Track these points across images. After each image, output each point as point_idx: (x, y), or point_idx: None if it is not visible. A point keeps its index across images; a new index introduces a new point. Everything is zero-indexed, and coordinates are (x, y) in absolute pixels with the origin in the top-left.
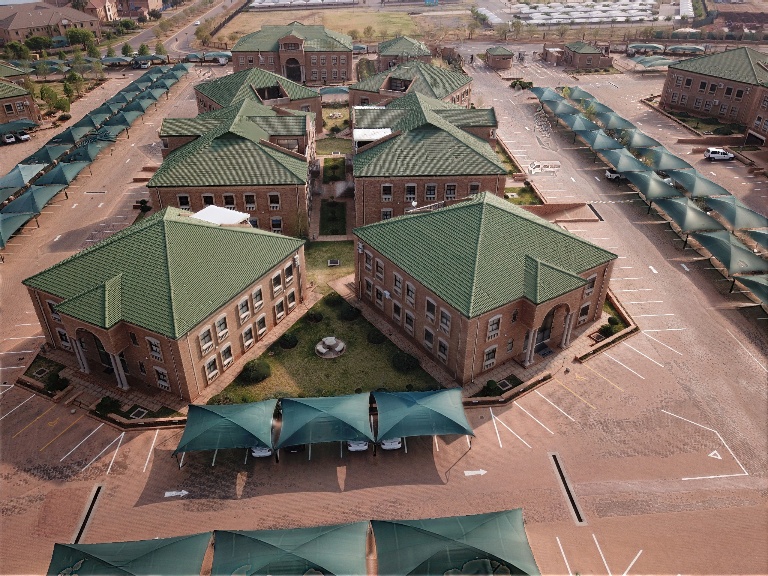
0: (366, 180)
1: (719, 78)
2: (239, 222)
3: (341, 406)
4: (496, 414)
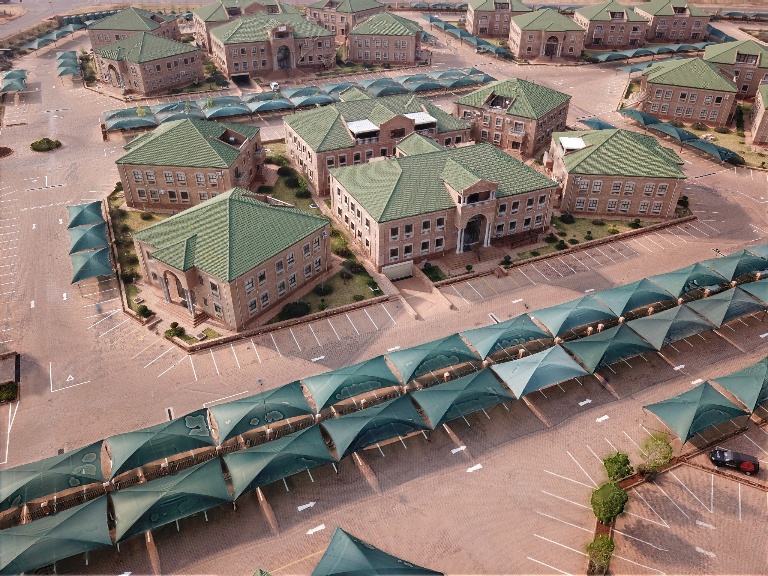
0: None
1: (177, 55)
2: None
3: None
4: None
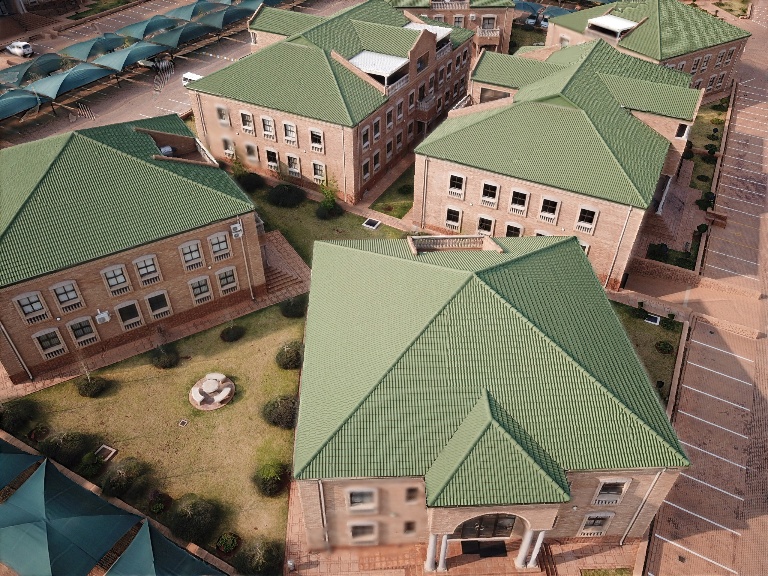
0: None
1: None
2: None
3: (556, 9)
4: None
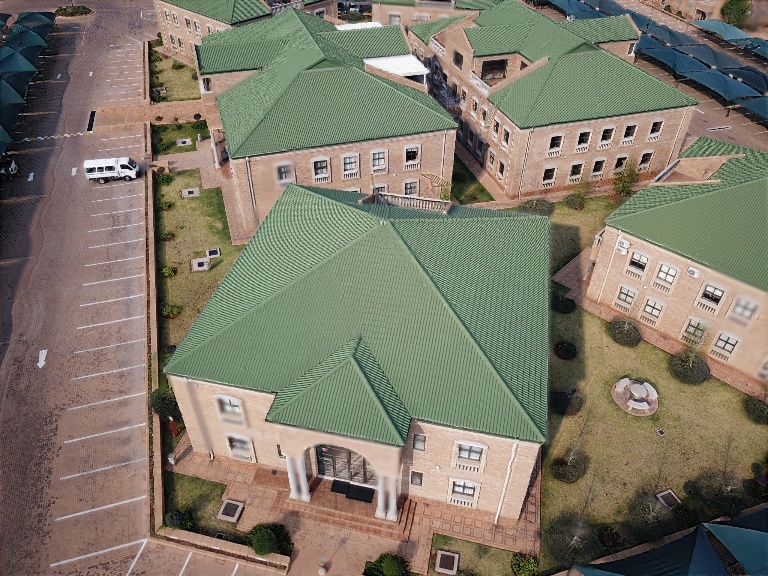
0: None
1: None
2: None
3: None
4: None
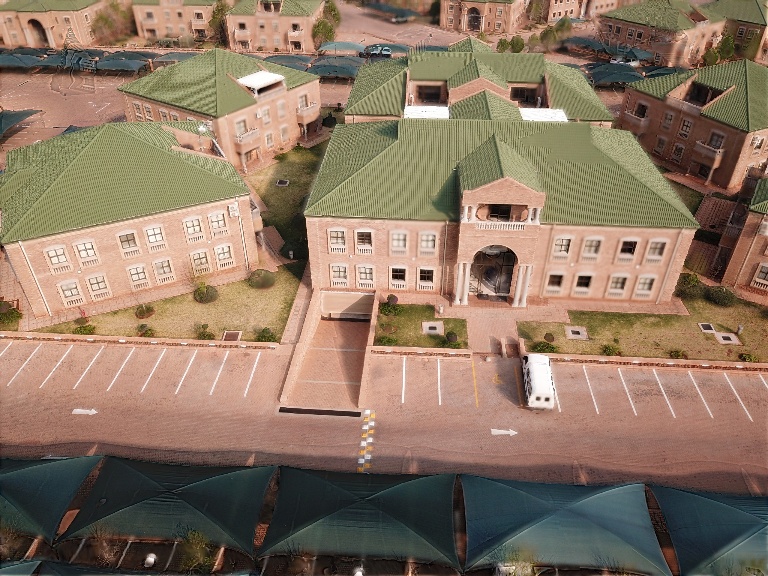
0: None
1: None
2: (246, 85)
3: None
4: None
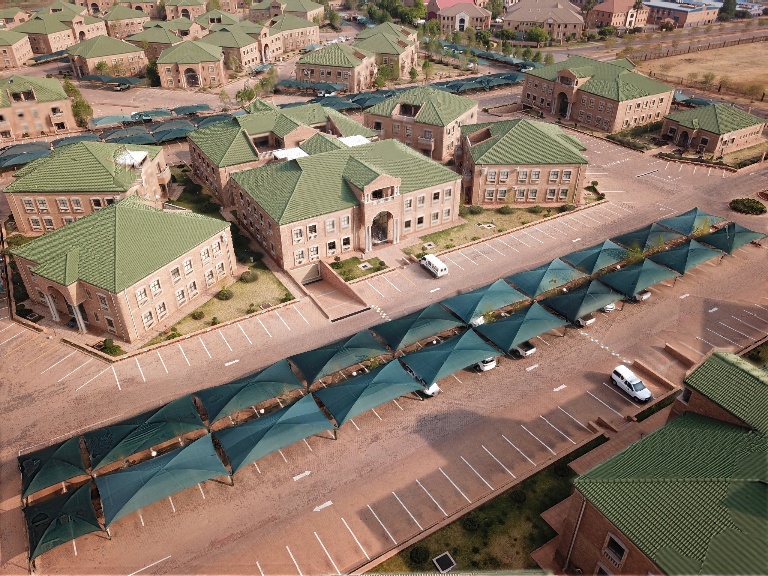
0: (235, 182)
1: None
2: None
3: None
4: (2, 320)
